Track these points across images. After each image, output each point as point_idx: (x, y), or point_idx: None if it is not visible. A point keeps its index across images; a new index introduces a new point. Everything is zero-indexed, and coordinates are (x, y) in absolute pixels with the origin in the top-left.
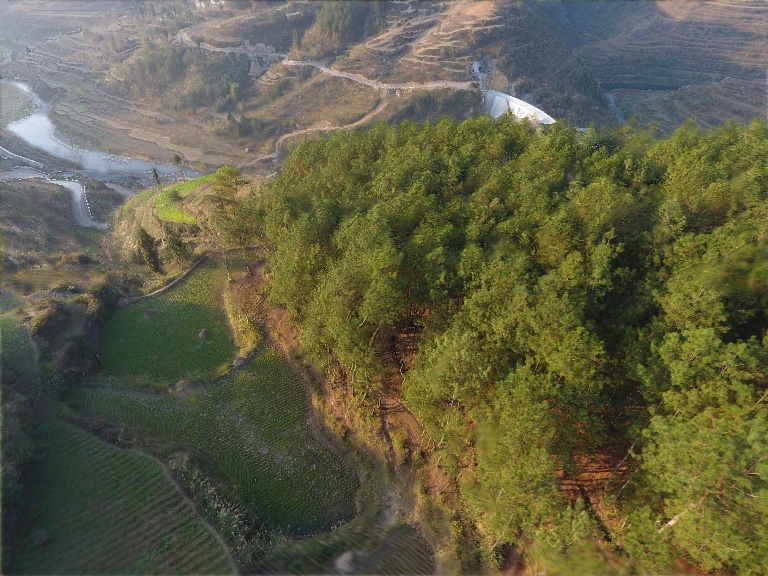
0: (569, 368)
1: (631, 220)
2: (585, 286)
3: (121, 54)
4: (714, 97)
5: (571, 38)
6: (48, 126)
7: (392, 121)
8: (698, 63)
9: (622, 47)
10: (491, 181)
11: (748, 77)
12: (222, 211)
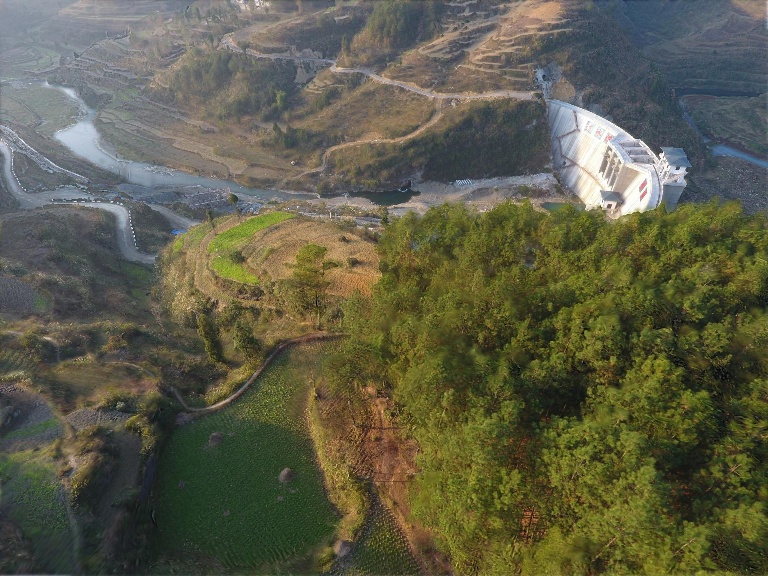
0: None
1: None
2: None
3: (166, 59)
4: None
5: (632, 38)
6: (93, 134)
7: (448, 134)
8: None
9: (692, 49)
10: None
11: None
12: (302, 296)
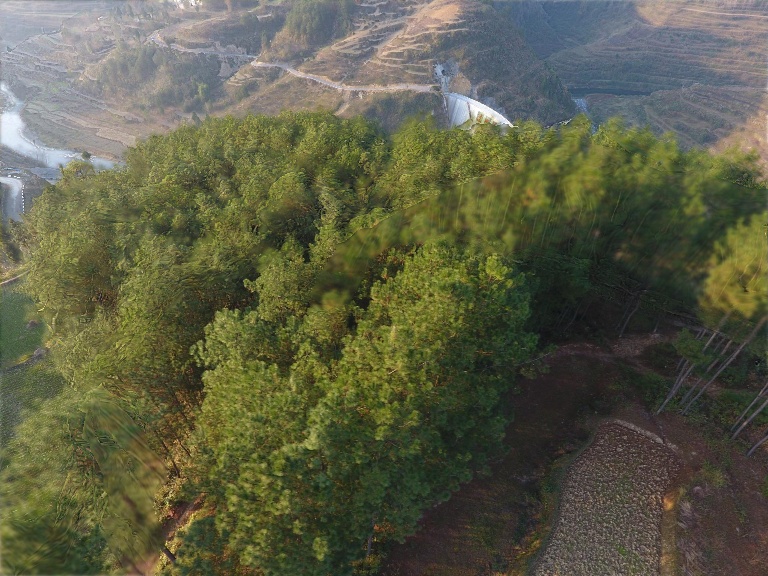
0: (137, 349)
1: (279, 208)
2: (214, 272)
3: (97, 54)
4: (682, 102)
5: (551, 43)
6: (18, 124)
7: None
8: (673, 69)
9: (598, 52)
10: (237, 173)
11: (723, 83)
12: None
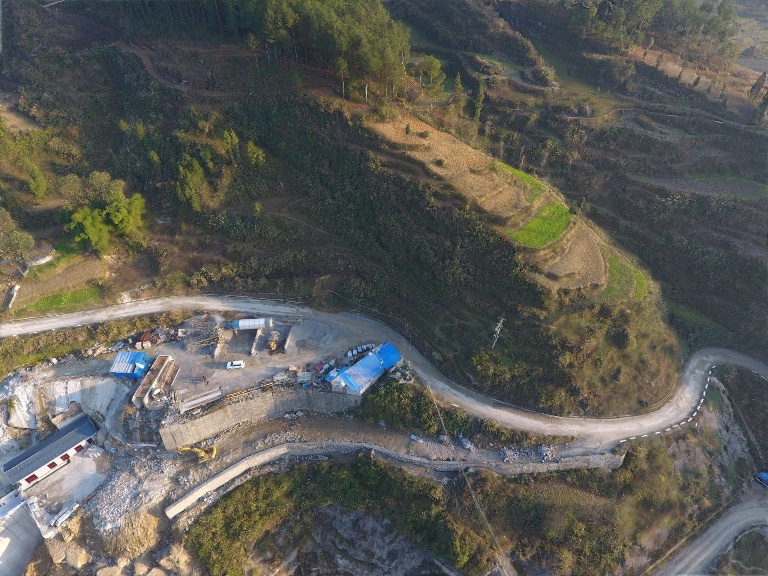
0: None
1: None
2: None
3: None
4: None
5: None
6: None
7: None
8: None
9: None
10: None
11: None
12: None
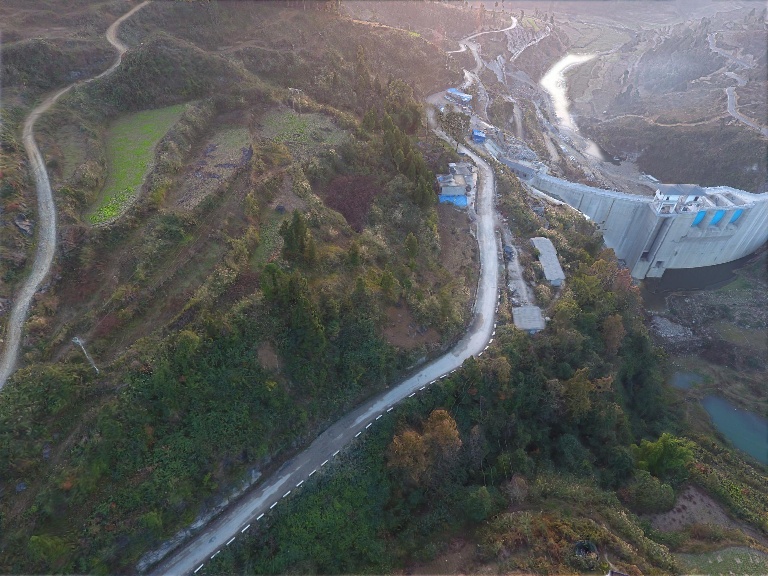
0: None
1: None
2: None
3: None
4: None
5: None
6: (583, 61)
7: (682, 136)
8: None
9: None
10: None
11: None
12: None
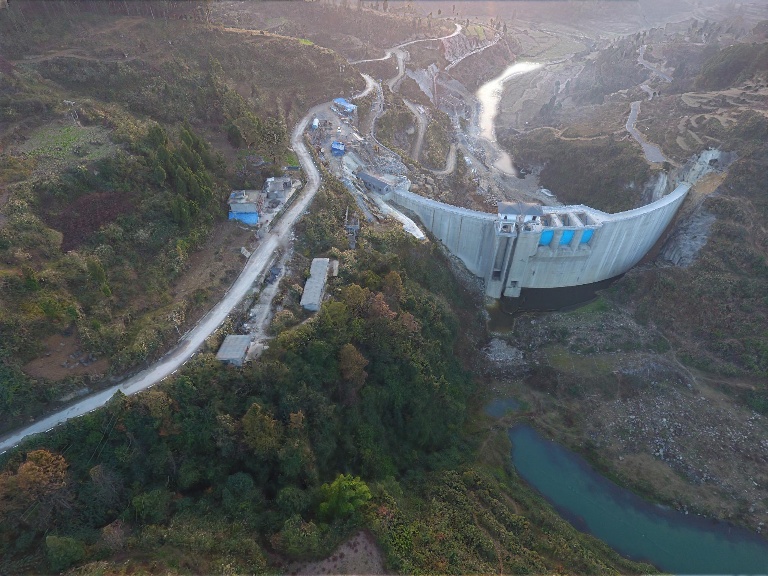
0: None
1: None
2: None
3: None
4: None
5: None
6: (528, 70)
7: (577, 150)
8: None
9: None
10: None
11: None
12: None
